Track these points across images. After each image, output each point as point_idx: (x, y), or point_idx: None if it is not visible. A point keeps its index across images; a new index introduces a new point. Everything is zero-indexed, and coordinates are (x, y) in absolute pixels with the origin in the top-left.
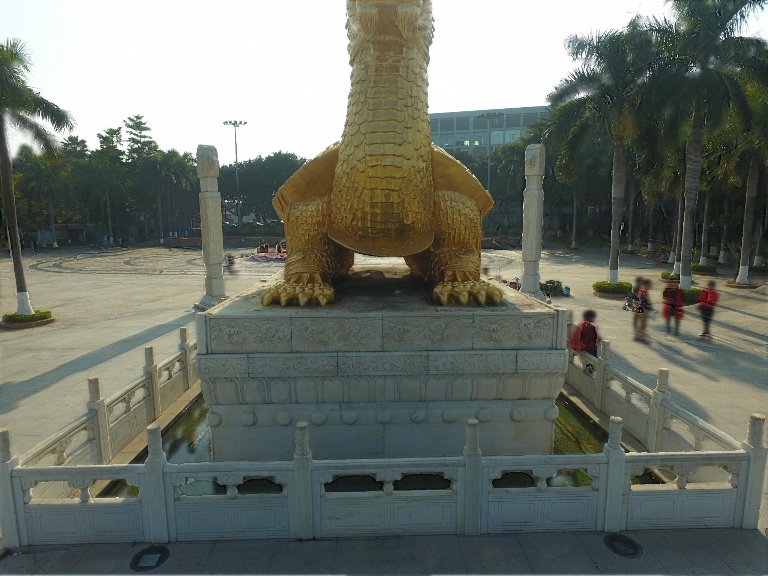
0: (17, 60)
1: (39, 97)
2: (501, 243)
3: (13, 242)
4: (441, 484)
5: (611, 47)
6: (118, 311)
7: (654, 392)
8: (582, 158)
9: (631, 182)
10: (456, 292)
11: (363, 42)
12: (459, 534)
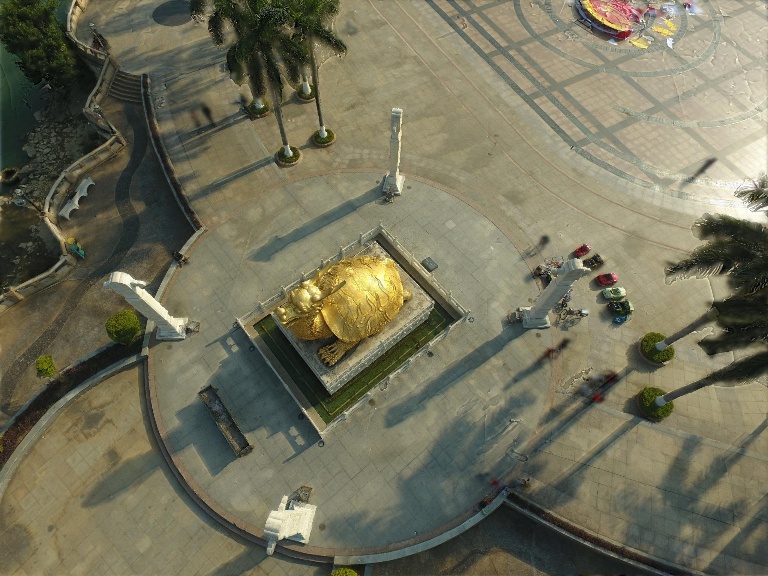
0: (317, 5)
1: (325, 36)
2: None
3: (317, 104)
4: None
5: None
6: (366, 141)
7: None
8: None
9: None
10: None
11: None
12: None
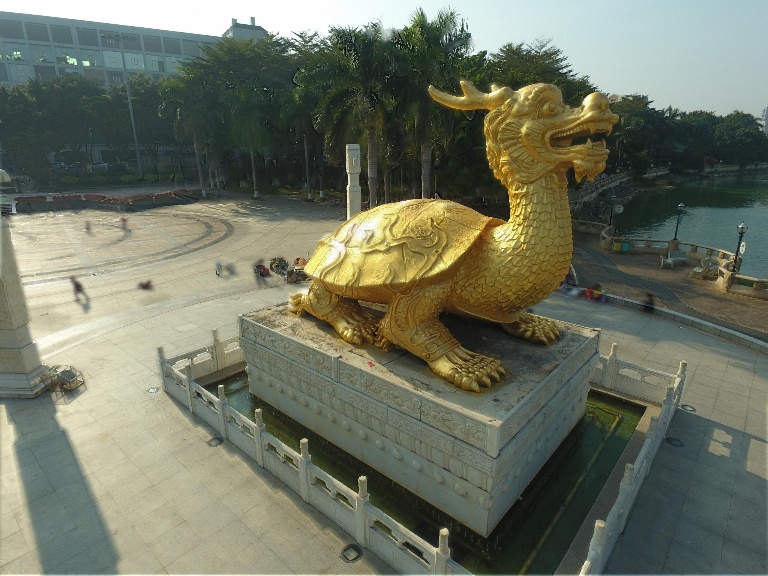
0: None
1: None
2: (181, 196)
3: None
4: (572, 458)
5: (363, 47)
6: None
7: (611, 357)
8: (344, 142)
9: (382, 165)
10: (547, 333)
11: (549, 172)
12: (645, 478)
